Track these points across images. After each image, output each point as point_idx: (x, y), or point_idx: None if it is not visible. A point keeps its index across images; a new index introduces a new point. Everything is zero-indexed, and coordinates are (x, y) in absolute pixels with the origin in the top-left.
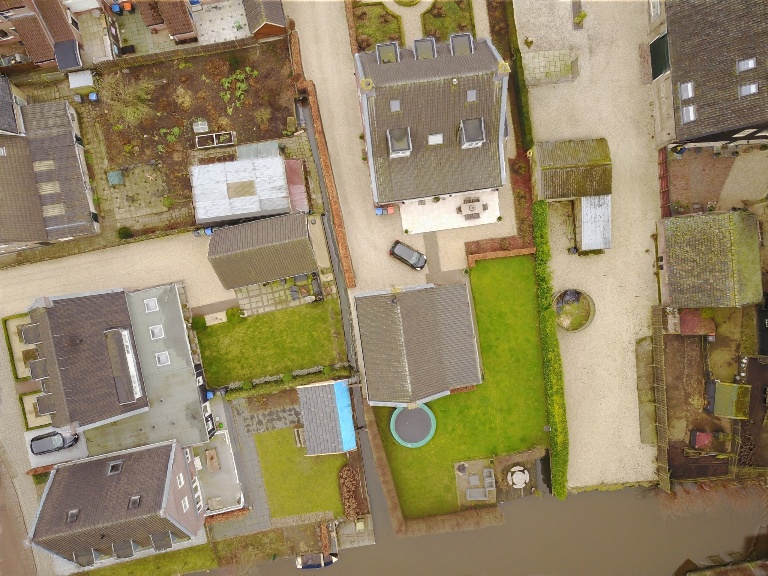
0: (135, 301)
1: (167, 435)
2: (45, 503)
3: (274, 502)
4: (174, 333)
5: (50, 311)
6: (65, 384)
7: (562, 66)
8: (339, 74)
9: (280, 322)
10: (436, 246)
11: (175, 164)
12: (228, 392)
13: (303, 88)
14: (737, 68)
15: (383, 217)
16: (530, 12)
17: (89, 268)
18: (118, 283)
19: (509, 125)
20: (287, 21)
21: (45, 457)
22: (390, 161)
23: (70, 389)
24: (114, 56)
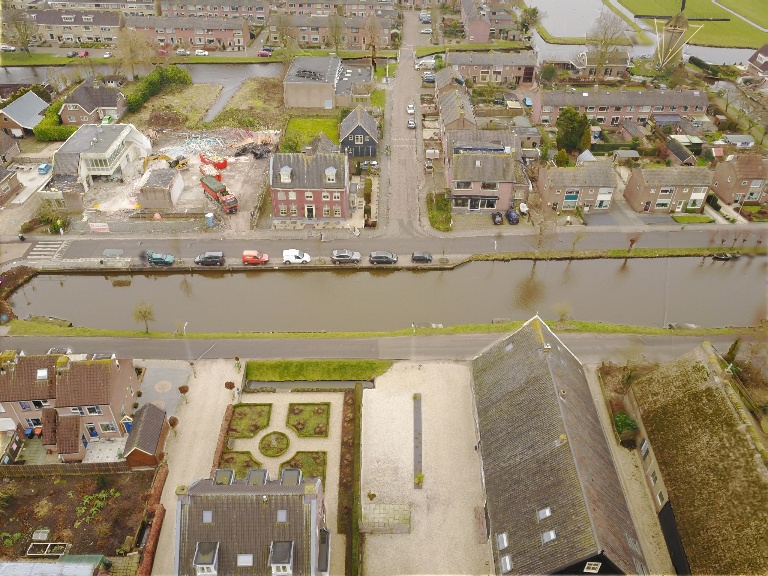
0: None
1: None
2: None
3: None
4: None
5: None
6: None
7: (401, 519)
8: None
9: None
10: None
11: None
12: None
13: (153, 511)
14: (537, 517)
15: None
16: (377, 472)
17: None
18: None
19: (341, 569)
20: (158, 452)
21: None
22: None
23: None
24: (0, 463)
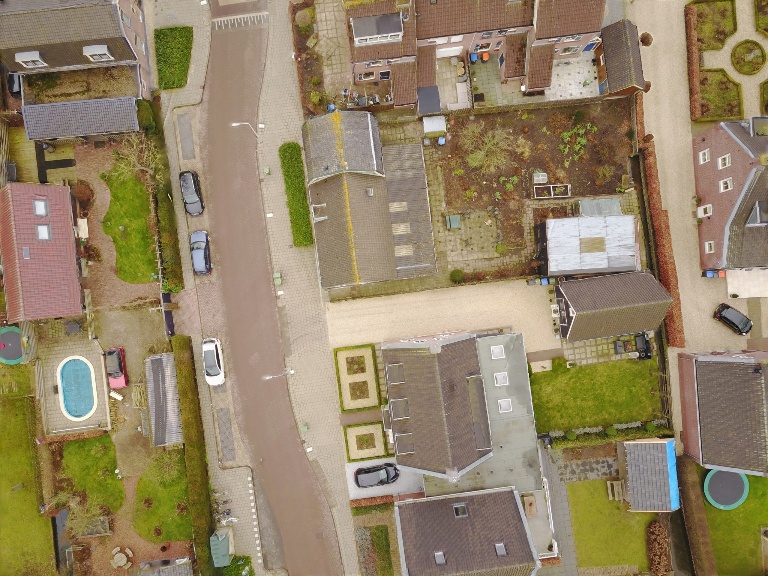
0: (481, 347)
1: (503, 481)
2: (405, 542)
3: (582, 552)
4: (517, 381)
5: (438, 357)
6: (449, 430)
7: None
8: (676, 136)
9: (601, 375)
10: (759, 312)
11: (510, 212)
12: (553, 441)
13: (642, 147)
14: None
15: (707, 279)
16: None
17: (419, 307)
18: (446, 324)
19: None
20: (645, 83)
21: (364, 489)
22: (745, 230)
23: (451, 435)
24: (474, 105)
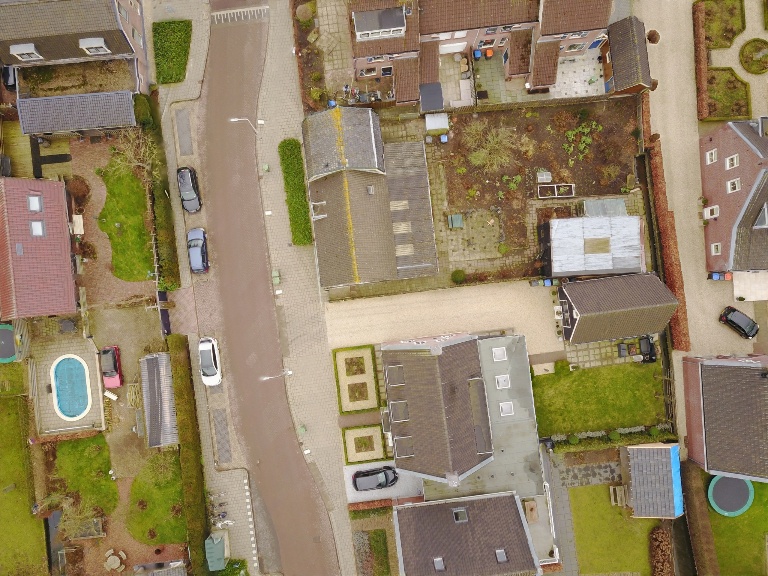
0: (483, 348)
1: (504, 485)
2: (404, 547)
3: (583, 558)
4: (519, 384)
5: (438, 359)
6: (449, 433)
7: None
8: (682, 136)
9: (604, 378)
10: (766, 316)
11: (513, 212)
12: (555, 445)
13: (648, 147)
14: None
15: (713, 282)
16: None
17: (420, 308)
18: (447, 325)
19: None
20: (651, 82)
21: (362, 493)
22: (752, 232)
23: (452, 438)
24: (477, 102)
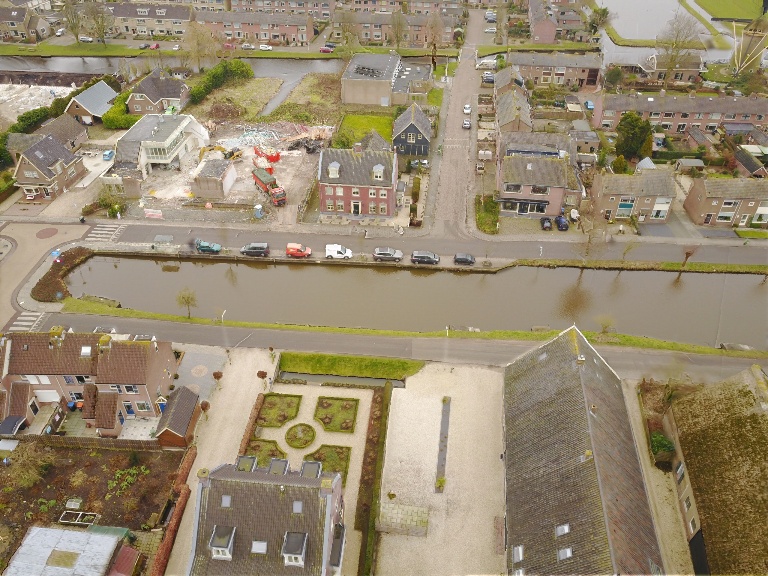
0: None
1: None
2: None
3: None
4: None
5: None
6: None
7: (418, 521)
8: None
9: None
10: None
11: None
12: None
13: (179, 491)
14: (555, 533)
15: None
16: (399, 472)
17: None
18: None
19: (354, 566)
20: (188, 434)
21: None
22: (211, 561)
23: None
24: (43, 432)
